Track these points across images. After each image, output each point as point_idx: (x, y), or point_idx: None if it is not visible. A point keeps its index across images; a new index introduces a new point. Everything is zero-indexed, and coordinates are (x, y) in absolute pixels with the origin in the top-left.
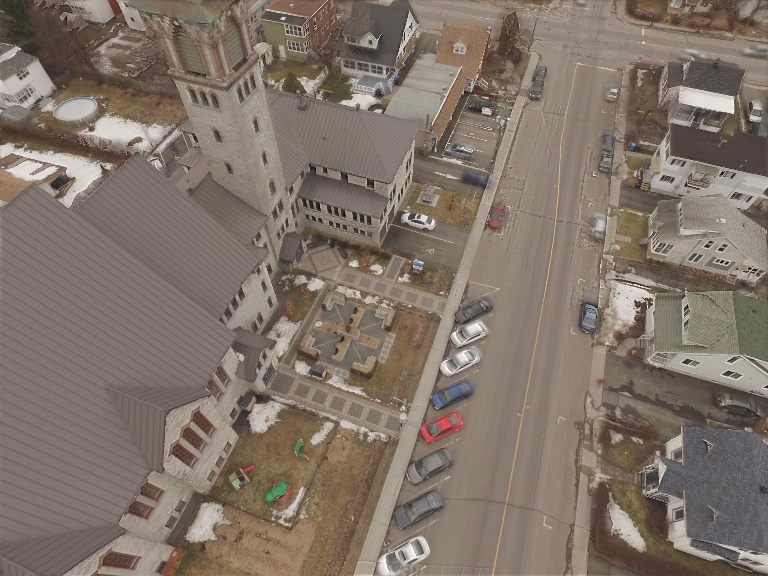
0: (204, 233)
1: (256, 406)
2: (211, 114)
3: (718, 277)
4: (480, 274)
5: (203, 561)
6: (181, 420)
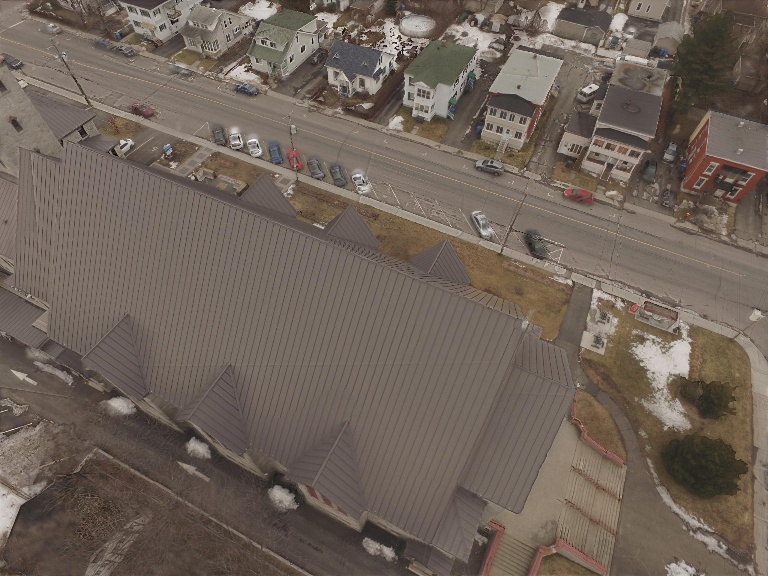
0: None
1: None
2: (2, 103)
3: (243, 40)
4: (190, 129)
5: None
6: None
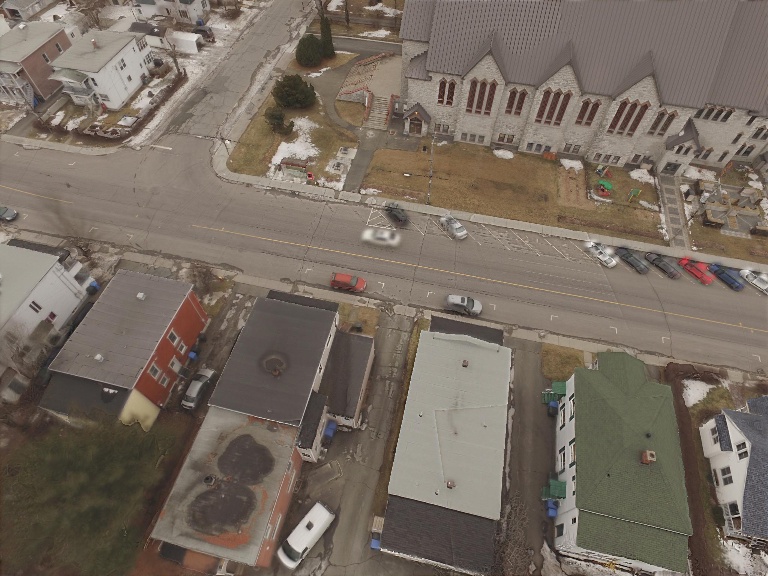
0: (764, 64)
1: (646, 170)
2: None
3: None
4: None
5: (555, 167)
6: (643, 95)
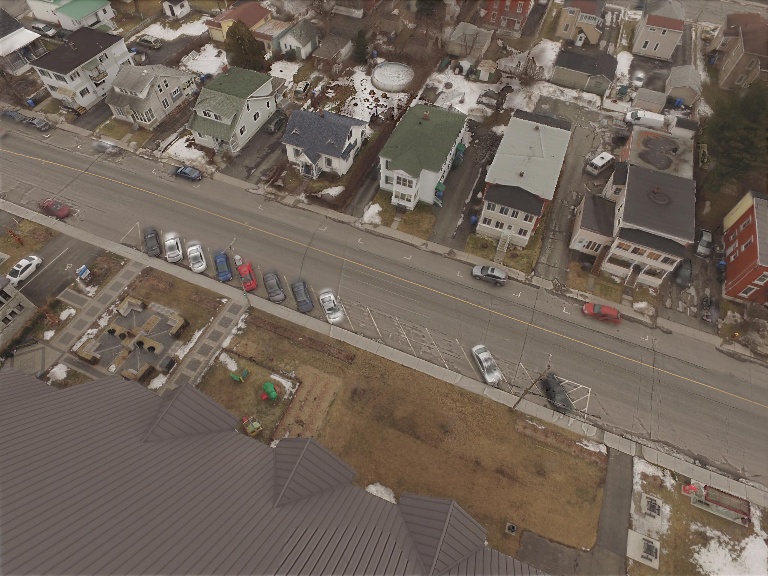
0: None
1: None
2: None
3: (185, 102)
4: (115, 233)
5: None
6: None
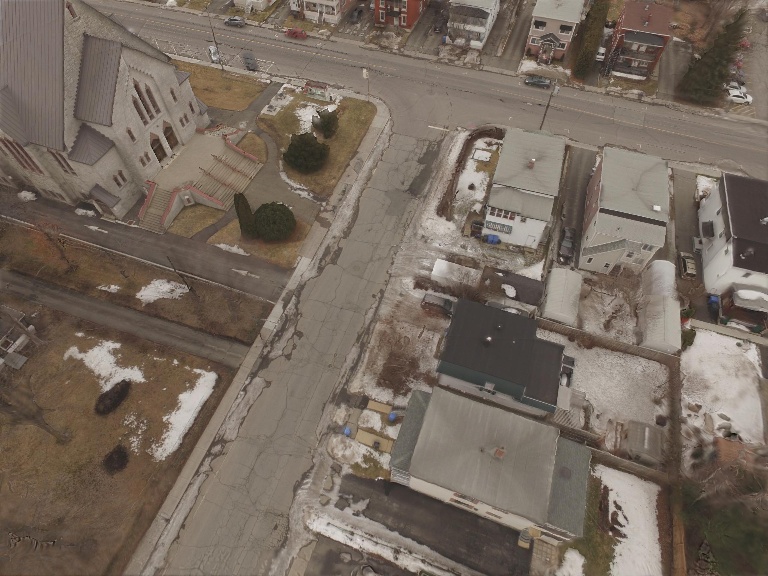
0: None
1: None
2: None
3: None
4: None
5: None
6: None
